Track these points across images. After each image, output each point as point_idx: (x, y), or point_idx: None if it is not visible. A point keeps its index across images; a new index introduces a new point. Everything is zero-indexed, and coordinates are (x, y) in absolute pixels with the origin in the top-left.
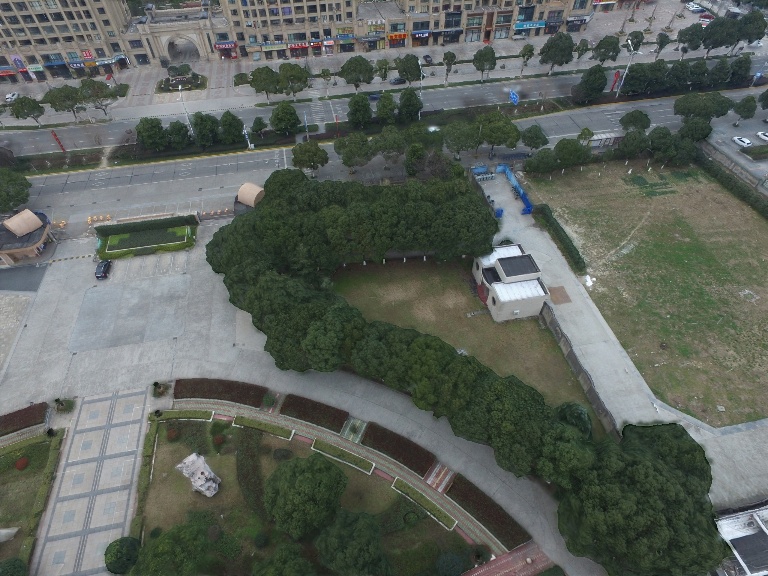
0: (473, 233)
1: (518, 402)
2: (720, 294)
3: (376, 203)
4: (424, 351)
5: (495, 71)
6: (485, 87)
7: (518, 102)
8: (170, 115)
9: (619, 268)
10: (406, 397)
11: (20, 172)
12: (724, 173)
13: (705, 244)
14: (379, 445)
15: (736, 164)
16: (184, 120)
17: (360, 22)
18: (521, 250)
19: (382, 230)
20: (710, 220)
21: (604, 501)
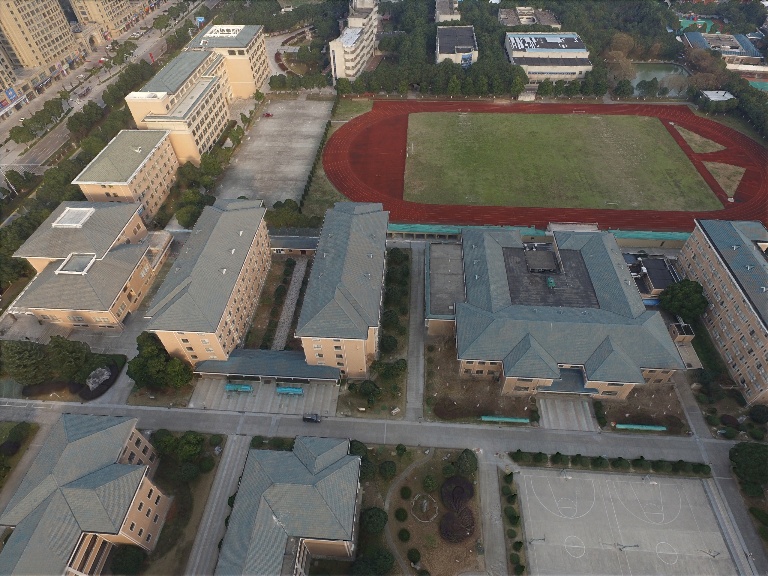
0: (278, 3)
1: None
2: None
3: (262, 4)
4: (305, 4)
5: (190, 5)
6: (199, 8)
7: (216, 5)
8: (146, 50)
9: None
10: (306, 27)
11: (158, 69)
12: None
13: (296, 0)
14: (314, 28)
15: None
16: (154, 48)
17: (136, 6)
18: (283, 8)
19: (269, 7)
20: None
21: (338, 0)
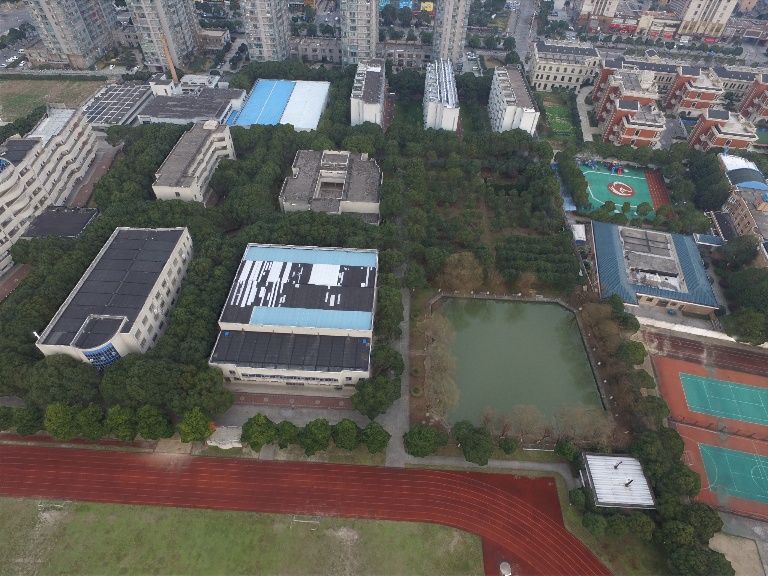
0: None
1: (1, 126)
2: (39, 100)
3: None
4: None
5: None
6: None
7: None
8: None
9: (4, 112)
10: None
11: None
12: (6, 75)
13: (23, 94)
14: None
15: (7, 71)
16: None
17: None
18: None
19: None
20: (18, 89)
21: None
